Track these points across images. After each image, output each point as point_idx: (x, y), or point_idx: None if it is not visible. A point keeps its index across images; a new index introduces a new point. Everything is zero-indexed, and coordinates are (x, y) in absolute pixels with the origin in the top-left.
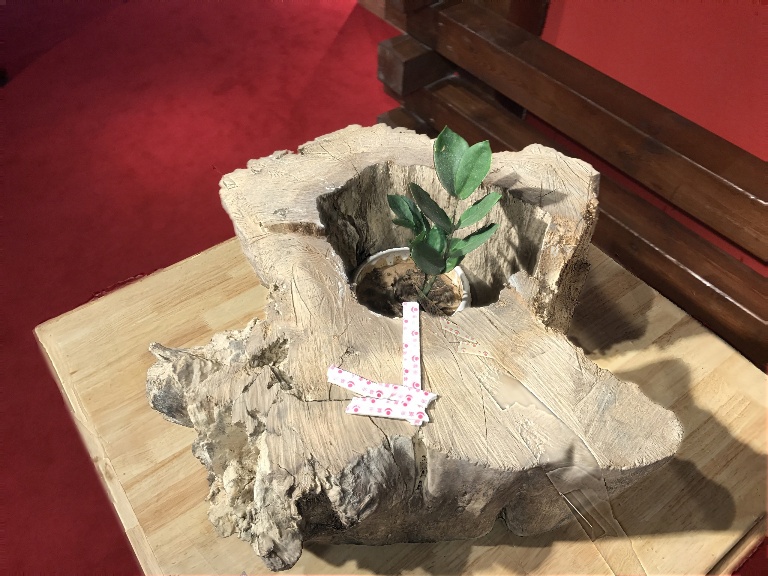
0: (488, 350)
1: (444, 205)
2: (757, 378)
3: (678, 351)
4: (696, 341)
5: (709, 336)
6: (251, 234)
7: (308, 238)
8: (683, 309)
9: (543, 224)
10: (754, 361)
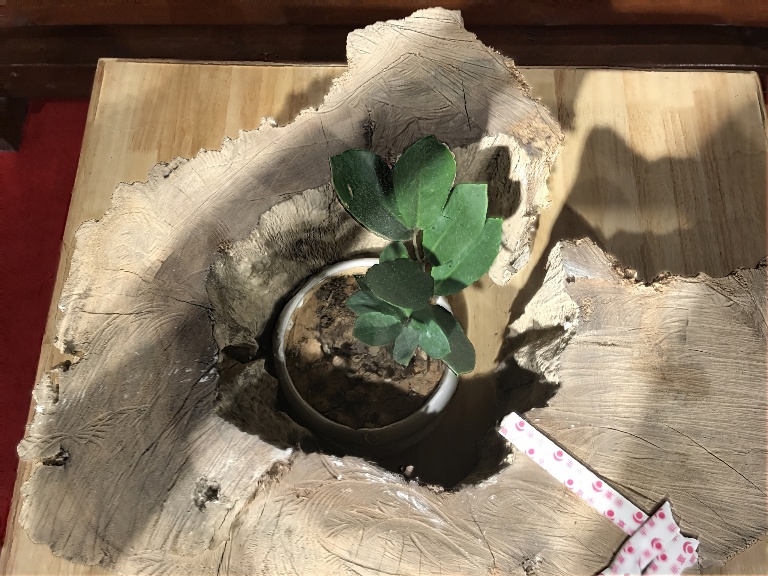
0: (639, 382)
1: (322, 219)
2: (660, 83)
3: (585, 118)
4: (587, 92)
5: (590, 76)
6: (208, 572)
7: (280, 480)
8: (537, 65)
9: (494, 149)
10: (631, 64)
